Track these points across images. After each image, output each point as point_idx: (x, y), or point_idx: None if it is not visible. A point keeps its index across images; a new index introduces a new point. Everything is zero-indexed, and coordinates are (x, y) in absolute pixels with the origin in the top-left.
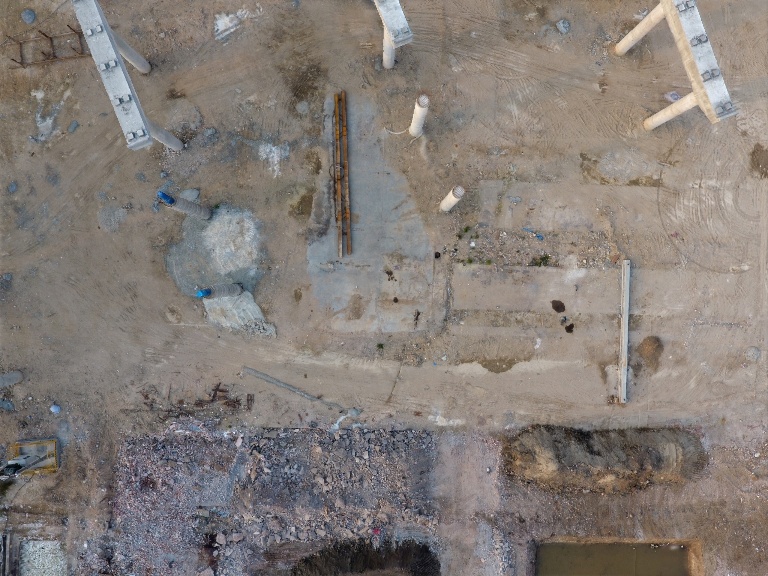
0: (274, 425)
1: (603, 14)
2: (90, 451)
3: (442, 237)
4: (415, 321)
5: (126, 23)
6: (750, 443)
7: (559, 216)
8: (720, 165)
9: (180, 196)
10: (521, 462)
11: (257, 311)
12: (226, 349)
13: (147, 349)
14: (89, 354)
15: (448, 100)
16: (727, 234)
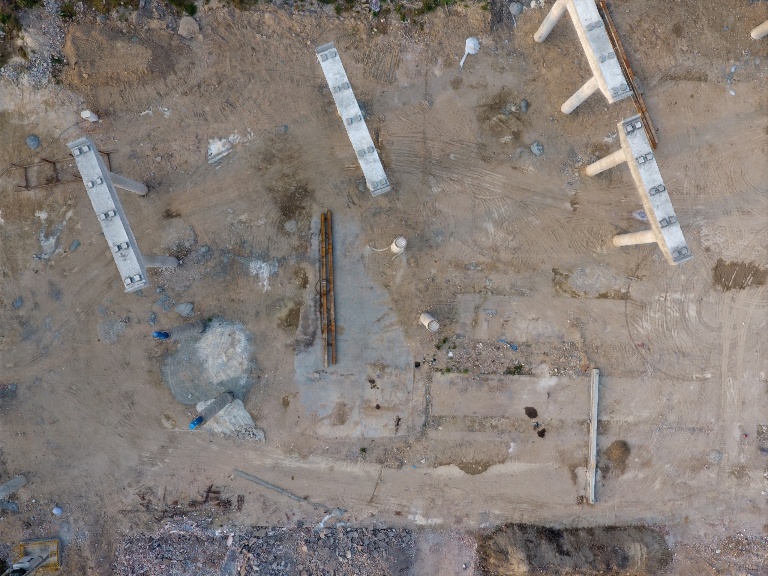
0: (263, 524)
1: (575, 137)
2: (90, 550)
3: (422, 348)
4: (396, 427)
5: (125, 148)
6: (711, 540)
7: (532, 327)
8: (685, 279)
9: (175, 310)
10: (495, 560)
11: (247, 417)
12: (218, 453)
13: (144, 453)
14: (89, 458)
15: (428, 219)
16: (691, 344)
